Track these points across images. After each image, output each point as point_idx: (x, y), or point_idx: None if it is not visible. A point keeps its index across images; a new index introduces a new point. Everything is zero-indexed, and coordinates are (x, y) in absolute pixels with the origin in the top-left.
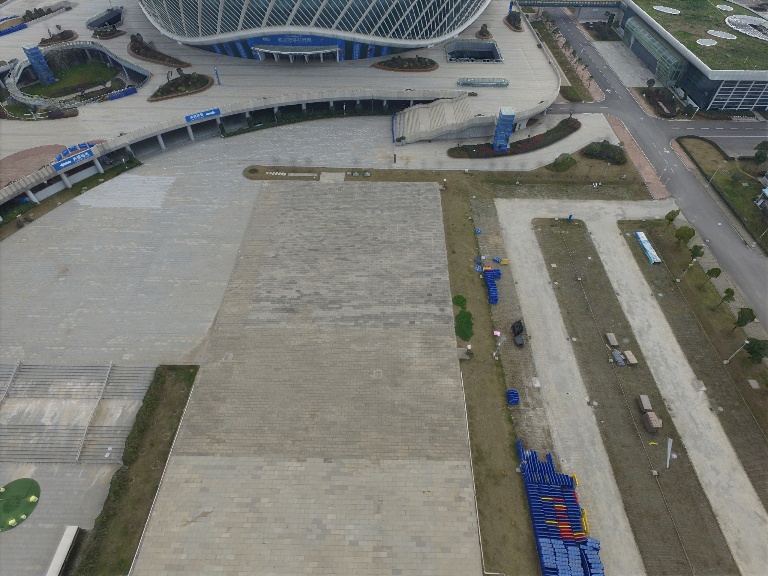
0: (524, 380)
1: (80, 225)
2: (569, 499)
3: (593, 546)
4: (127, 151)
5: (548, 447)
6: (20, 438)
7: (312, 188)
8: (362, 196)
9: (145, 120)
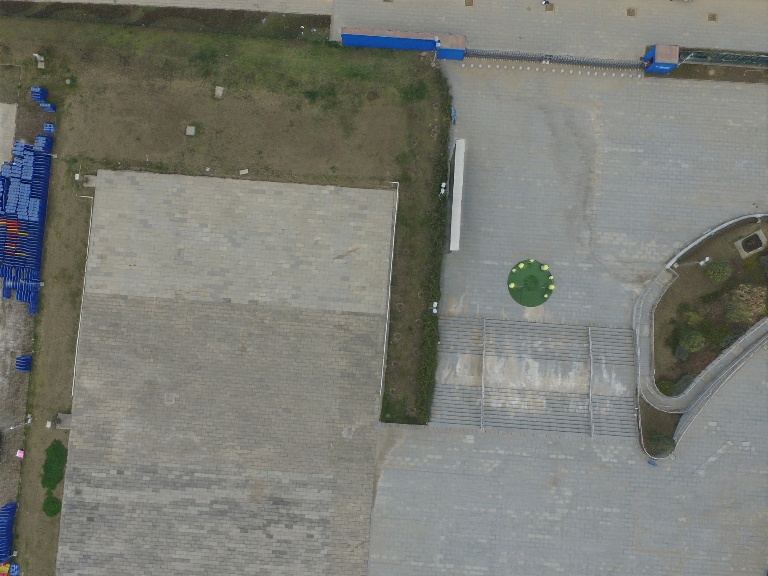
0: (7, 386)
1: None
2: None
3: None
4: None
5: (6, 306)
6: (553, 347)
7: None
8: None
9: None
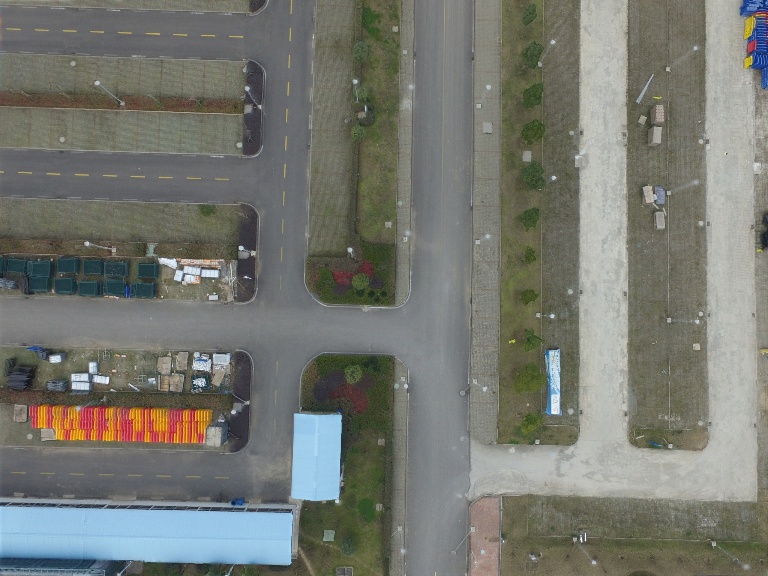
0: None
1: None
2: (764, 42)
3: (755, 4)
4: None
5: (761, 97)
6: None
7: None
8: None
9: None
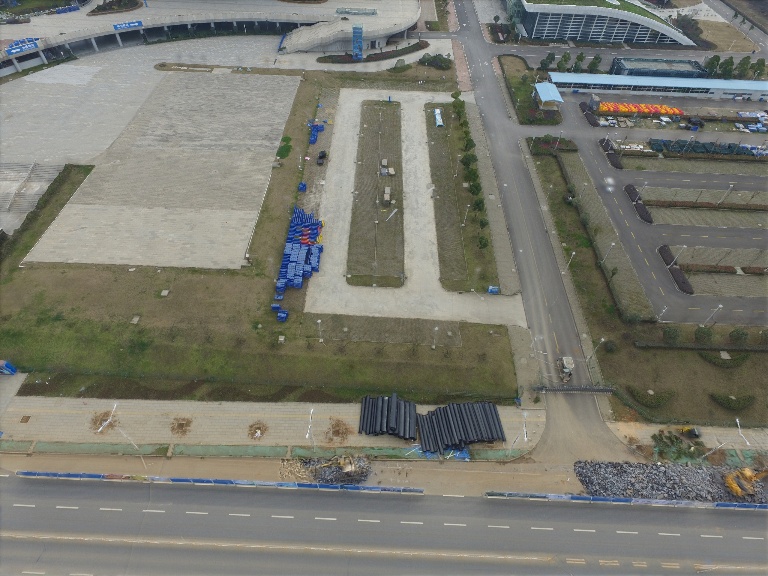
0: (315, 181)
1: (25, 92)
2: (313, 228)
3: (317, 246)
4: (66, 48)
5: (315, 210)
6: None
7: (204, 76)
8: (240, 82)
9: (82, 27)
